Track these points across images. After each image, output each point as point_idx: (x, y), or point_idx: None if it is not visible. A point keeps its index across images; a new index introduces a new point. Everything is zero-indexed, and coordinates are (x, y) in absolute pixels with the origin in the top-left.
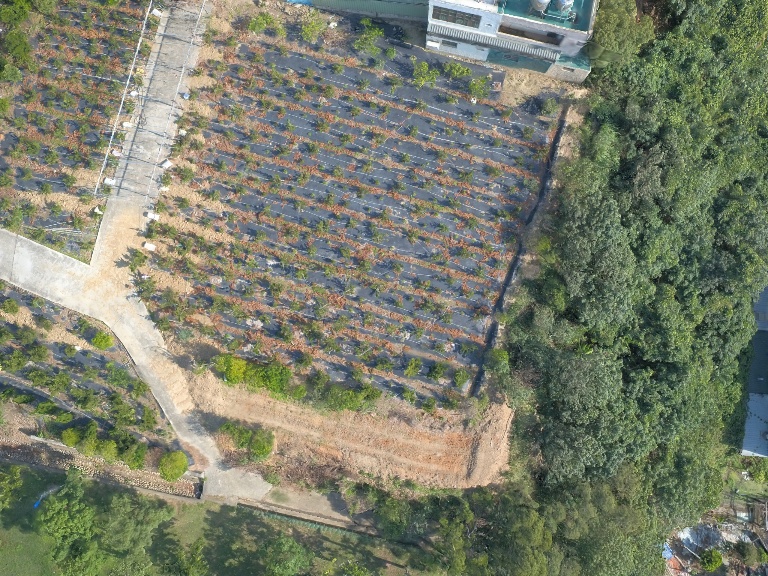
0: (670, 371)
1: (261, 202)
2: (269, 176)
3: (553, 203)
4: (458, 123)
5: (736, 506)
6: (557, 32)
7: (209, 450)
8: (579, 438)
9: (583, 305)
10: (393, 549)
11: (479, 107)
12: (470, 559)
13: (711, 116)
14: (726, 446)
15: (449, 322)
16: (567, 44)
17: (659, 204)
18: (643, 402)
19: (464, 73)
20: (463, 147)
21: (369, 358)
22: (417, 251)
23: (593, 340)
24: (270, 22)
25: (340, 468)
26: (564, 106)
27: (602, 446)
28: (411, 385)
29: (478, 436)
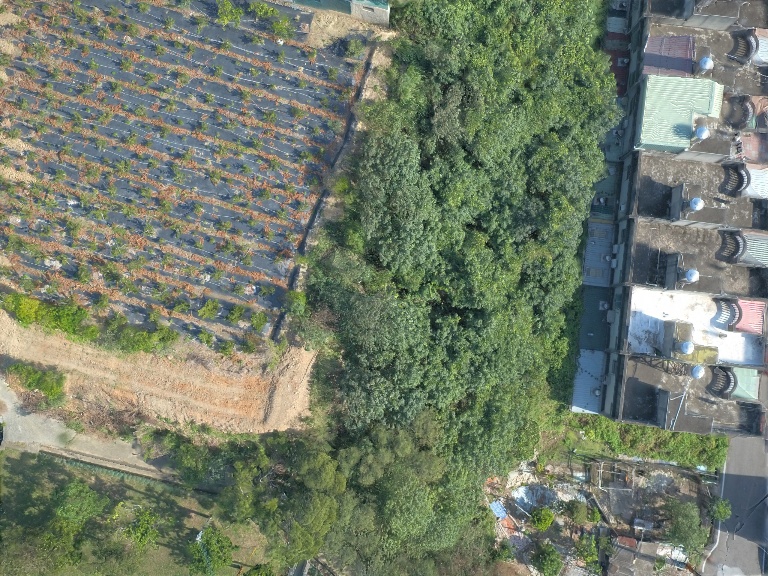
0: (477, 318)
1: (63, 141)
2: (71, 115)
3: (359, 146)
4: (264, 64)
5: (573, 466)
6: None
7: (6, 394)
8: (371, 380)
9: (381, 247)
10: (199, 498)
11: (285, 48)
12: (257, 502)
13: (522, 62)
14: (555, 402)
15: (249, 264)
16: None
17: (464, 148)
18: (453, 350)
19: (268, 13)
20: (268, 88)
21: (168, 300)
22: (219, 192)
23: (400, 286)
24: None
25: (138, 413)
26: (371, 49)
27: (398, 390)
28: (211, 328)
29: (275, 380)
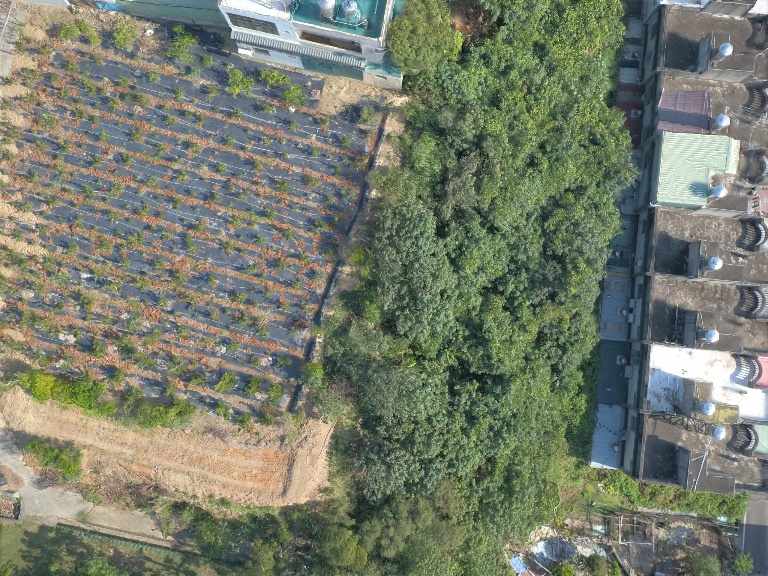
0: (495, 383)
1: (74, 214)
2: (83, 187)
3: (373, 213)
4: (276, 132)
5: (592, 519)
6: (350, 39)
7: (23, 469)
8: (391, 454)
9: (398, 317)
10: (218, 569)
11: (297, 115)
12: None
13: (537, 124)
14: (574, 458)
15: (265, 335)
16: (367, 51)
17: (479, 213)
18: (472, 415)
19: (279, 81)
20: (280, 156)
21: (184, 373)
22: (234, 263)
23: (417, 352)
24: (85, 30)
25: (156, 486)
26: (384, 114)
27: (418, 461)
28: (228, 400)
29: (294, 452)
